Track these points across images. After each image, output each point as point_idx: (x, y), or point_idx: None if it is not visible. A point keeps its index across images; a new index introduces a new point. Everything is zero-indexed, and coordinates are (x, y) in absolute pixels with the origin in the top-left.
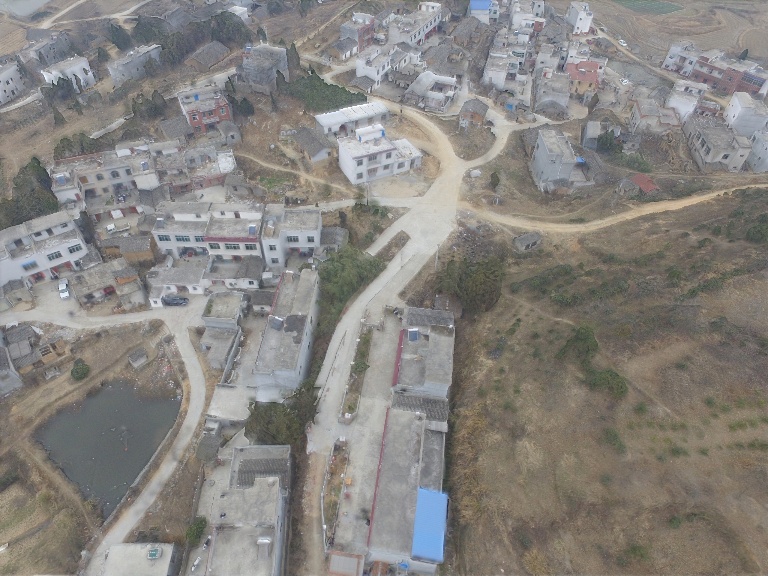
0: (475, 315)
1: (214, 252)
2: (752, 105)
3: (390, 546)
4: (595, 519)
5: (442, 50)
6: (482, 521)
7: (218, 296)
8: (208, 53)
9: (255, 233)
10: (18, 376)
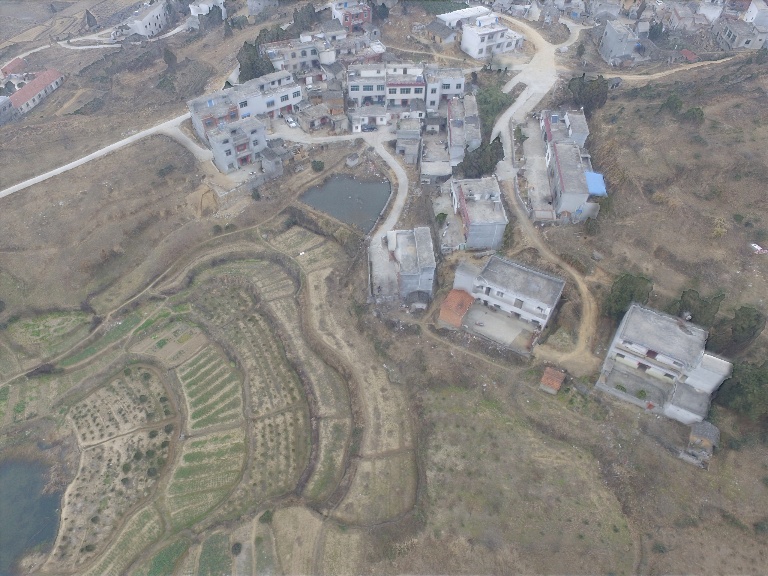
0: (591, 112)
1: (391, 97)
2: (767, 8)
3: (576, 191)
4: (691, 180)
5: None
6: (624, 187)
7: (402, 121)
8: None
9: (421, 81)
10: (282, 166)
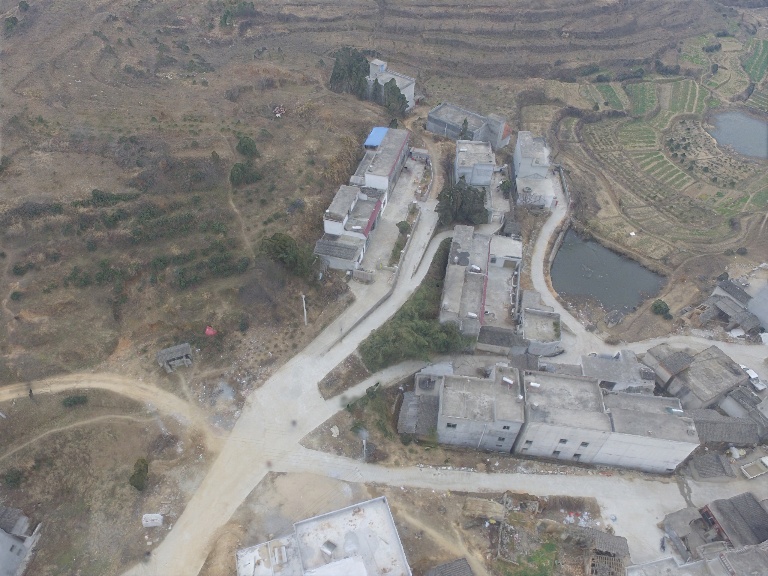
0: None
1: None
2: None
3: (399, 131)
4: None
5: None
6: None
7: None
8: None
9: None
10: None
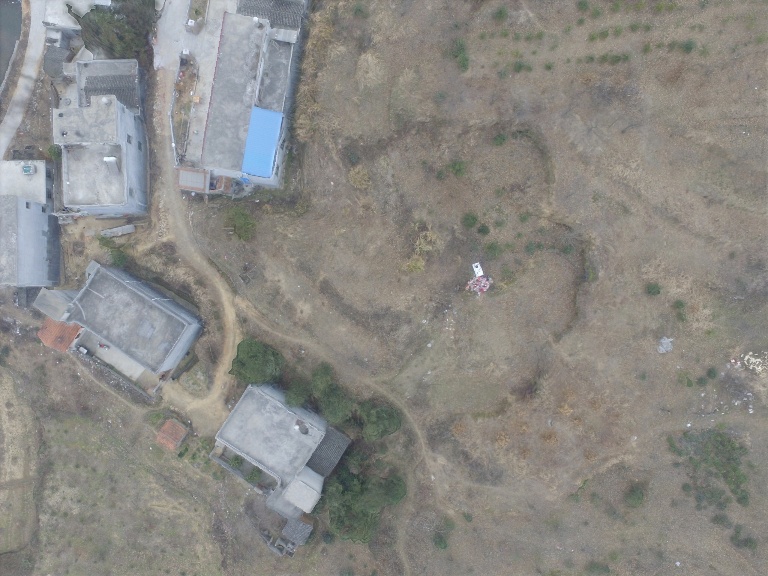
0: None
1: None
2: None
3: (222, 162)
4: (424, 136)
5: None
6: (317, 139)
7: None
8: None
9: None
10: None
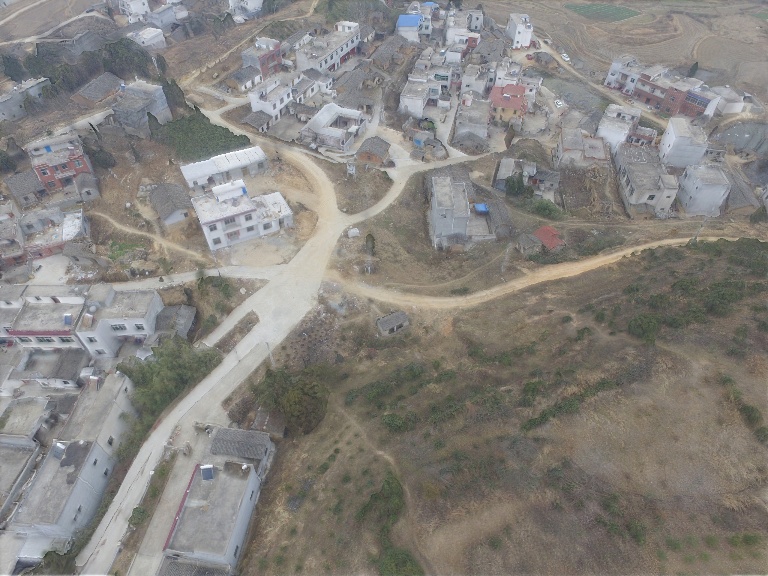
0: (294, 438)
1: (27, 345)
2: (687, 134)
3: None
4: None
5: (356, 76)
6: None
7: (20, 403)
8: (97, 87)
9: (71, 323)
10: None
